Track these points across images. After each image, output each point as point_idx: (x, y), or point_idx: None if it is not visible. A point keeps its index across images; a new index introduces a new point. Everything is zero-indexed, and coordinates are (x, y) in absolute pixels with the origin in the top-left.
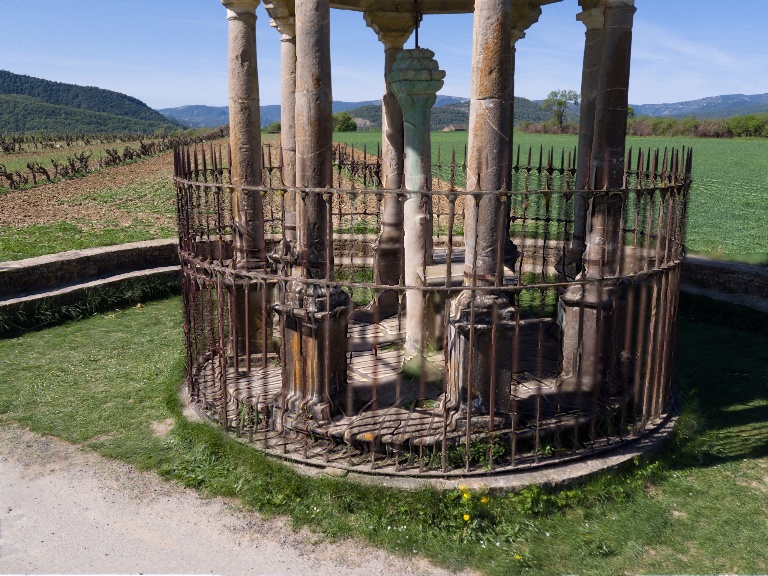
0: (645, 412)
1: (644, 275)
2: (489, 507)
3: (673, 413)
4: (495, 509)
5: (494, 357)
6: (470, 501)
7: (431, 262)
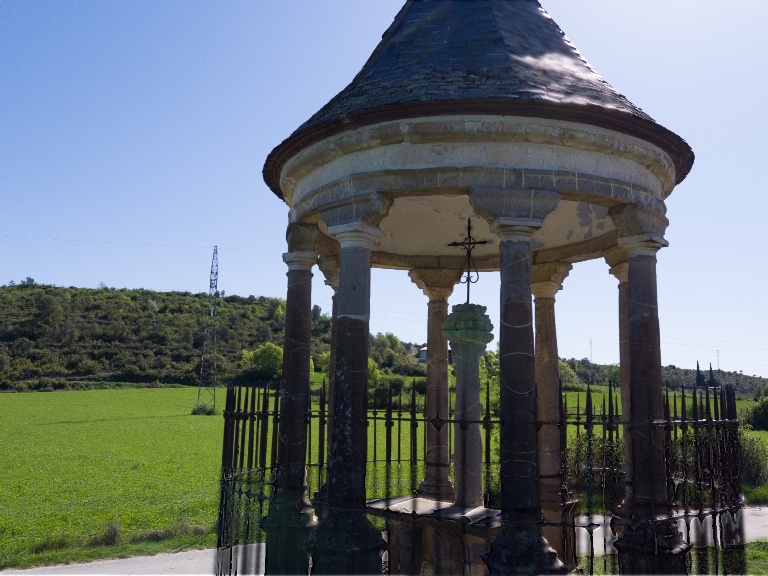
0: None
1: (243, 474)
2: None
3: None
4: None
5: None
6: None
7: None
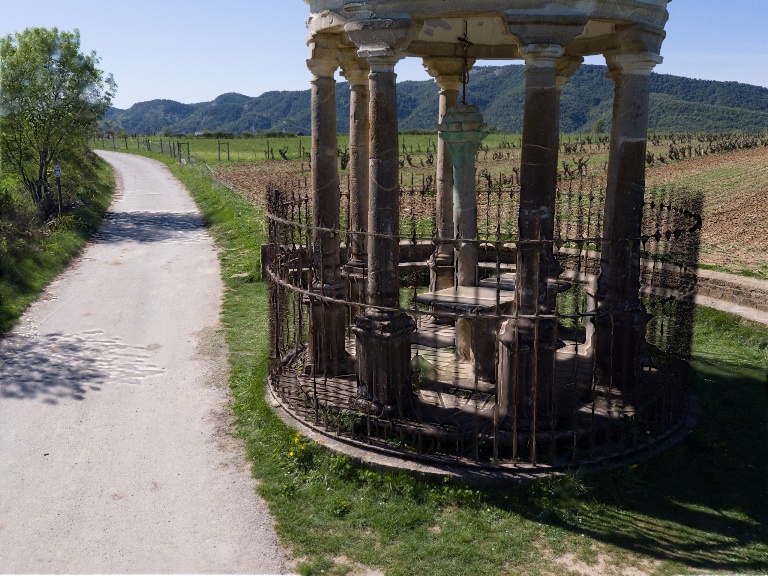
0: (495, 447)
1: (473, 317)
2: (315, 456)
3: (566, 470)
4: (318, 459)
5: (375, 357)
6: (300, 445)
7: (470, 284)
